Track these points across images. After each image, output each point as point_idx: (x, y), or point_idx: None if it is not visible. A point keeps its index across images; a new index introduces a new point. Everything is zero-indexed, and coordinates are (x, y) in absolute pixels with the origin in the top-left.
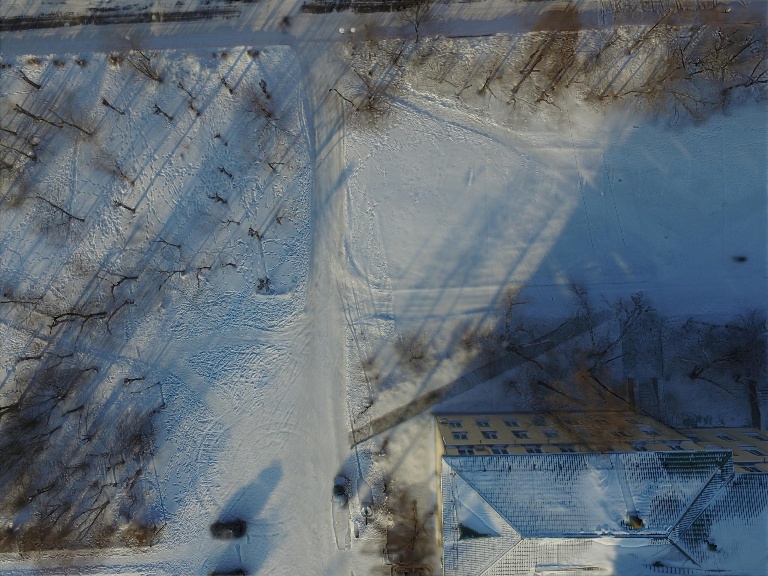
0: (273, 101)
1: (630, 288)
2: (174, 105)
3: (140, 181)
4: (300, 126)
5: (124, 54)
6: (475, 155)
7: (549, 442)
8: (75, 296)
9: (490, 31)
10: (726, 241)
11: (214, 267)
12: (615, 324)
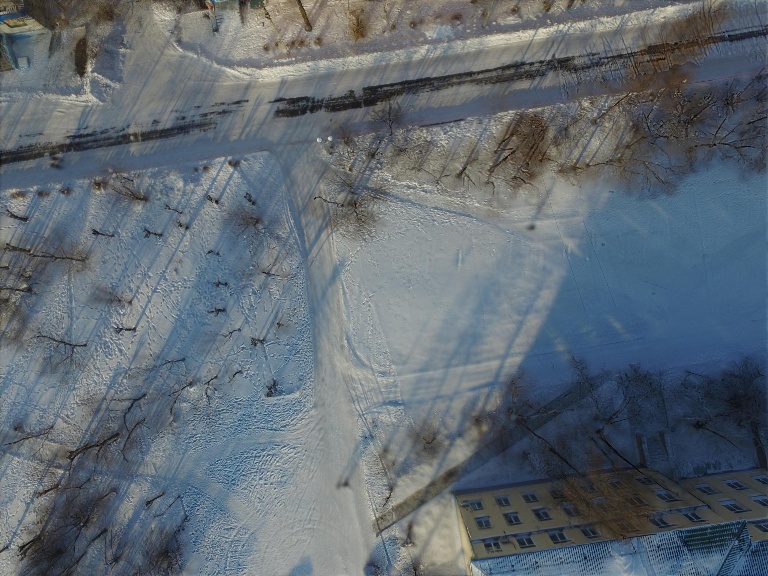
0: (259, 206)
1: (626, 346)
2: (162, 222)
3: (137, 300)
4: (288, 228)
5: (107, 178)
6: (461, 236)
7: (570, 524)
8: (86, 421)
9: (461, 115)
10: (711, 290)
11: (220, 375)
12: (616, 383)
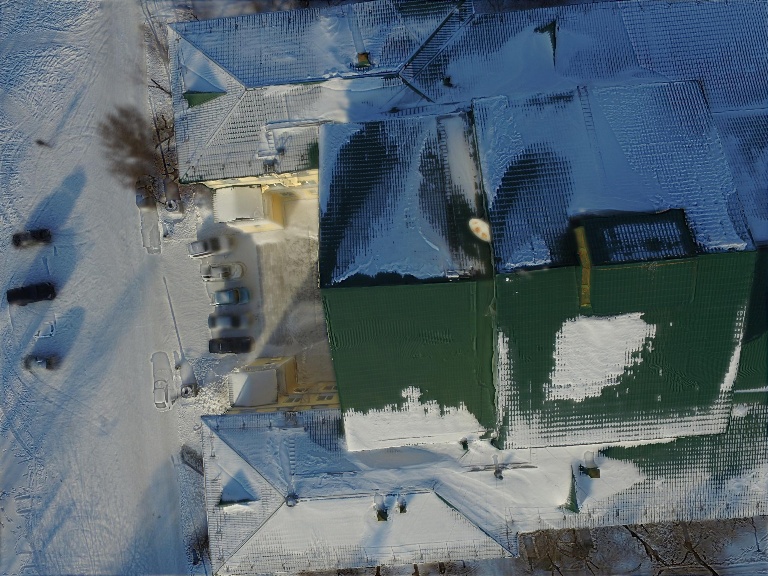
0: None
1: None
2: None
3: None
4: None
5: None
6: None
7: None
8: None
9: None
10: None
11: None
12: None
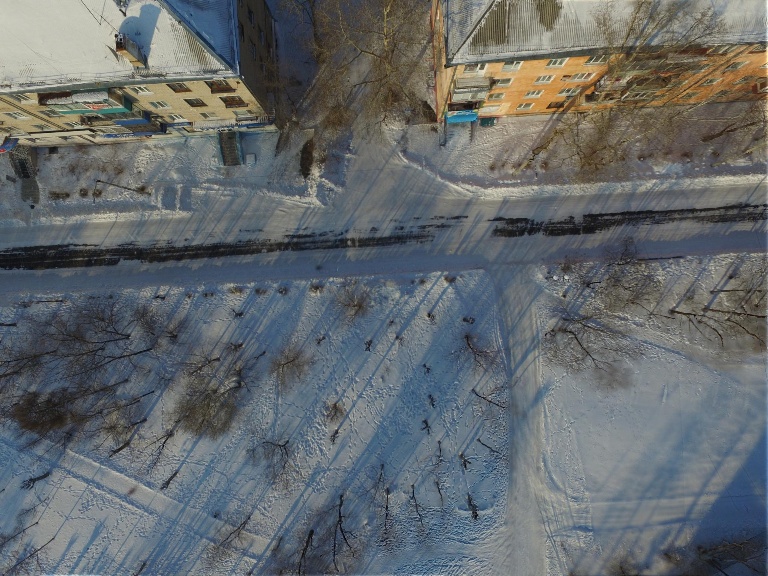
0: (469, 323)
1: None
2: (373, 329)
3: (342, 403)
4: (496, 347)
5: (323, 281)
6: (669, 373)
7: None
8: (282, 515)
9: (679, 252)
10: None
11: (417, 485)
12: None
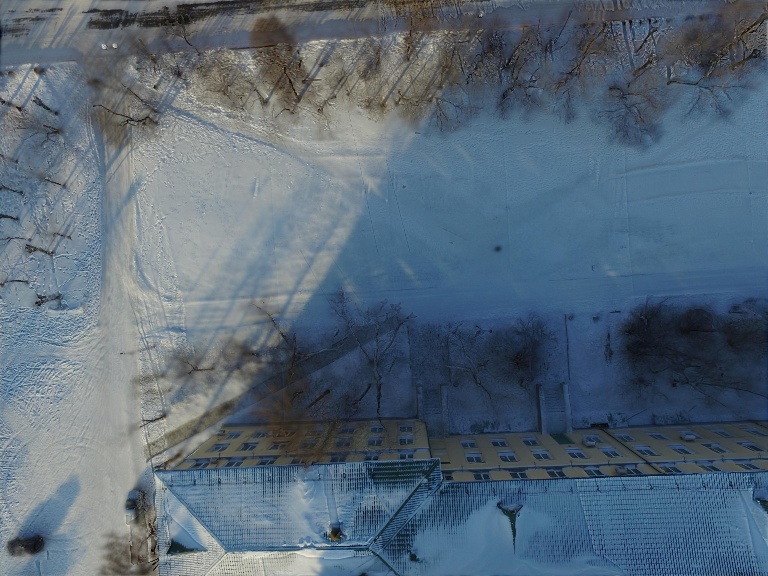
0: (62, 117)
1: (417, 294)
2: None
3: None
4: (89, 141)
5: None
6: (260, 165)
7: (287, 453)
8: None
9: (273, 42)
10: (511, 245)
11: (7, 284)
12: (403, 331)
